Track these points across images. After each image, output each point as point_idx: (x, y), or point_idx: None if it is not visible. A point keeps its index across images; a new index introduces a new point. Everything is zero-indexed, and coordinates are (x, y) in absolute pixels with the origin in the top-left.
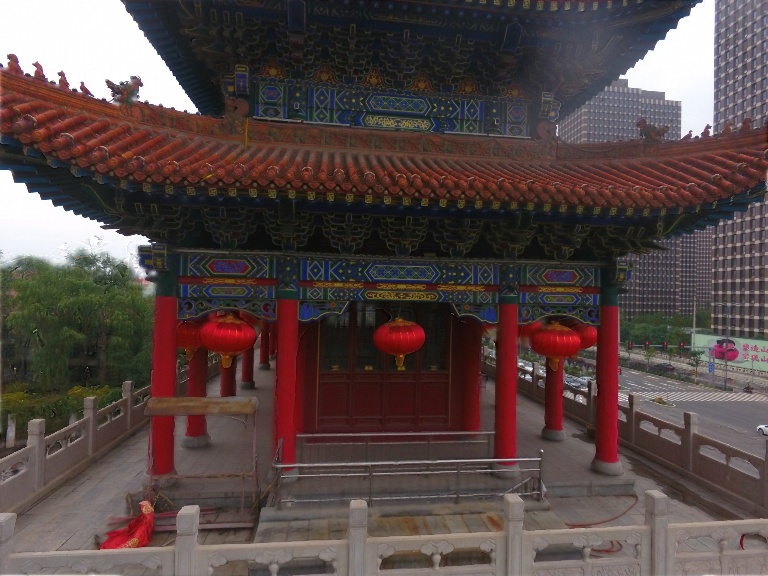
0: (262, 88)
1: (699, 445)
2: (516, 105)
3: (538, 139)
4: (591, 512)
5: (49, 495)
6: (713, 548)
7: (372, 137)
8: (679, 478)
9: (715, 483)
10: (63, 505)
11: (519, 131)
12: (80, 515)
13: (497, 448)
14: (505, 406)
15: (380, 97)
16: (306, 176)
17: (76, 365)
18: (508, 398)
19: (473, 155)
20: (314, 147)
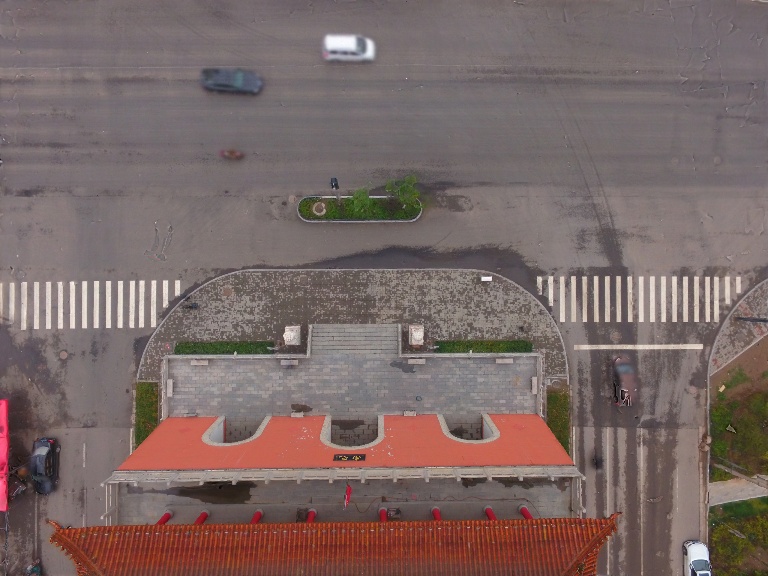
0: None
1: None
2: None
3: None
4: None
5: None
6: (556, 501)
7: None
8: None
9: None
10: None
11: None
12: None
13: None
14: None
15: None
16: None
17: None
18: None
19: None
20: None
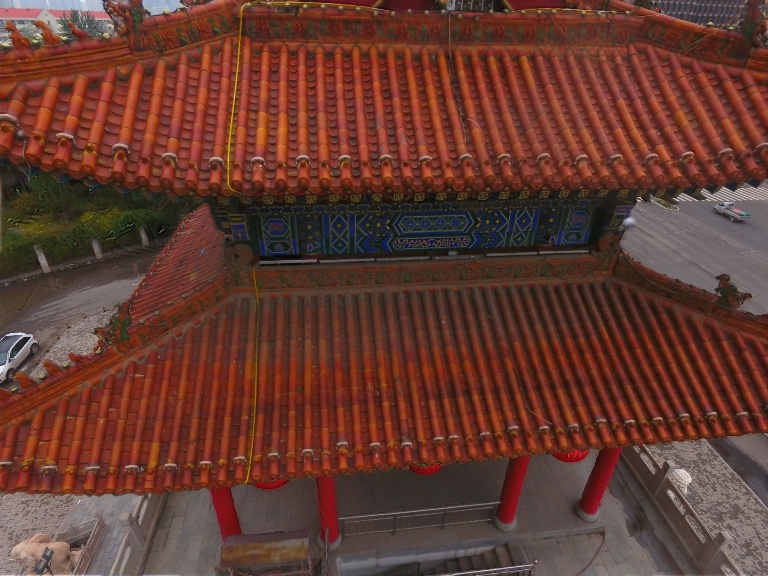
0: (264, 221)
1: (668, 488)
2: (580, 209)
3: (597, 251)
4: (565, 563)
5: (151, 546)
6: None
7: (401, 272)
8: (643, 500)
9: (670, 519)
10: (166, 562)
11: (576, 237)
12: None
13: (500, 510)
14: (512, 492)
15: (411, 218)
16: (343, 470)
17: (76, 181)
18: (515, 488)
19: (517, 278)
20: (334, 289)
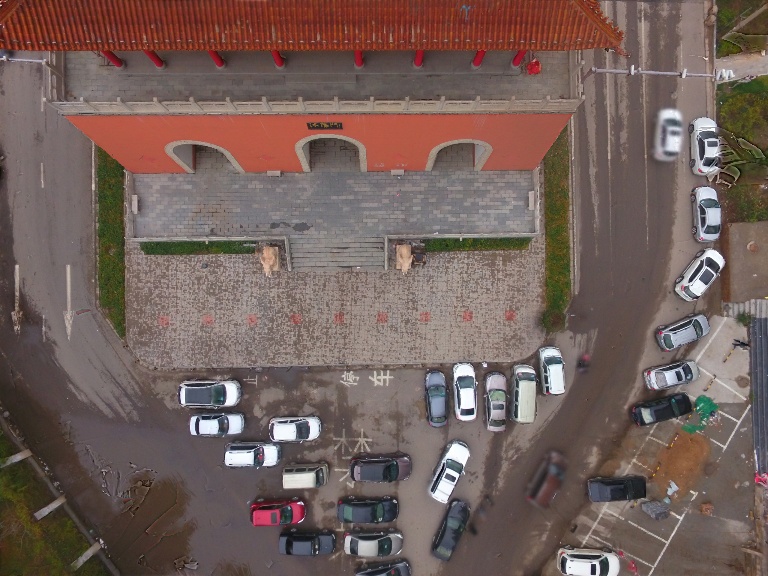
0: None
1: None
2: None
3: None
4: None
5: None
6: None
7: None
8: None
9: None
10: None
11: None
12: (519, 88)
13: None
14: None
15: None
16: None
17: None
18: None
19: None
20: None
